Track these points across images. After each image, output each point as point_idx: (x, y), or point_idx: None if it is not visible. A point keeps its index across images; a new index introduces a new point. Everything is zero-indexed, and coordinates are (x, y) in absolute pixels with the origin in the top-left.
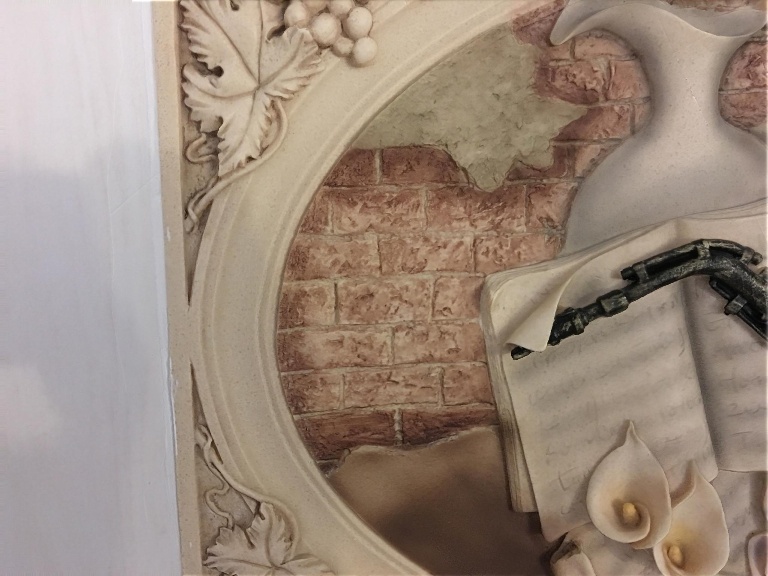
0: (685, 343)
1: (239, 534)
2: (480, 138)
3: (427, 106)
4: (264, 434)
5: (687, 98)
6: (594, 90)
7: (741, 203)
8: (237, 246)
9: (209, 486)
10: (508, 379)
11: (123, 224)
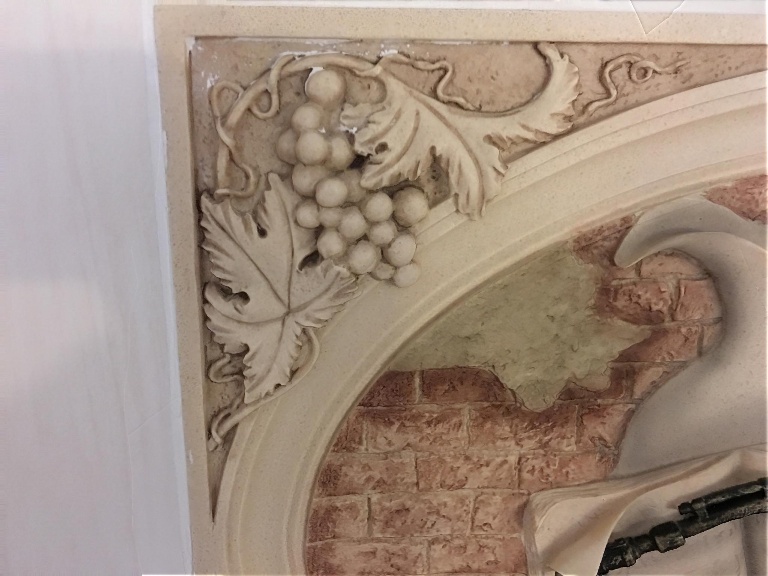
0: (741, 568)
1: None
2: (531, 360)
3: (474, 329)
4: None
5: (764, 326)
6: (660, 311)
7: None
8: (264, 461)
9: None
10: None
11: (142, 445)
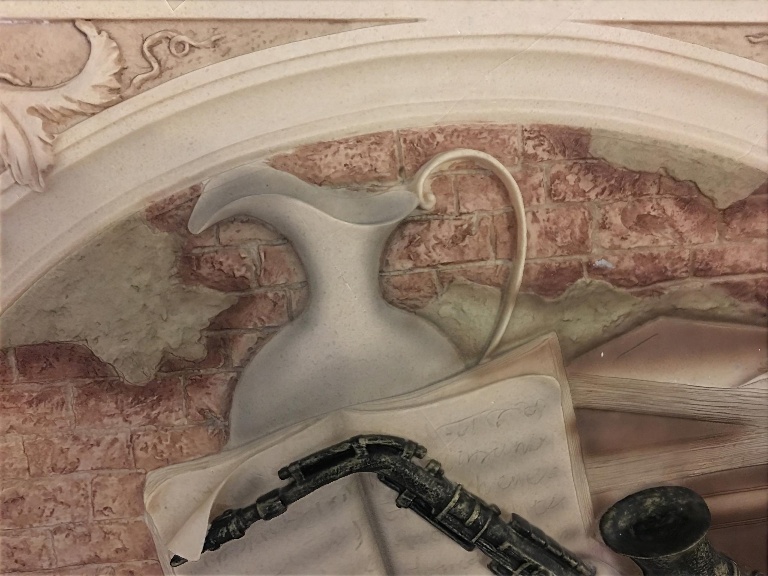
0: (363, 535)
1: None
2: (123, 332)
3: (58, 302)
4: None
5: (340, 285)
6: (244, 277)
7: (409, 389)
8: None
9: None
10: None
11: None
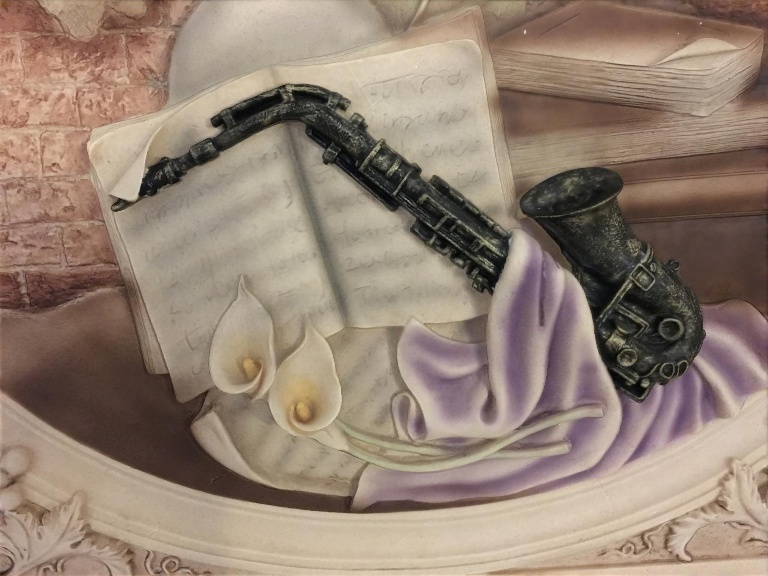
0: (293, 196)
1: None
2: None
3: None
4: None
5: None
6: None
7: (337, 51)
8: None
9: None
10: (122, 236)
11: None
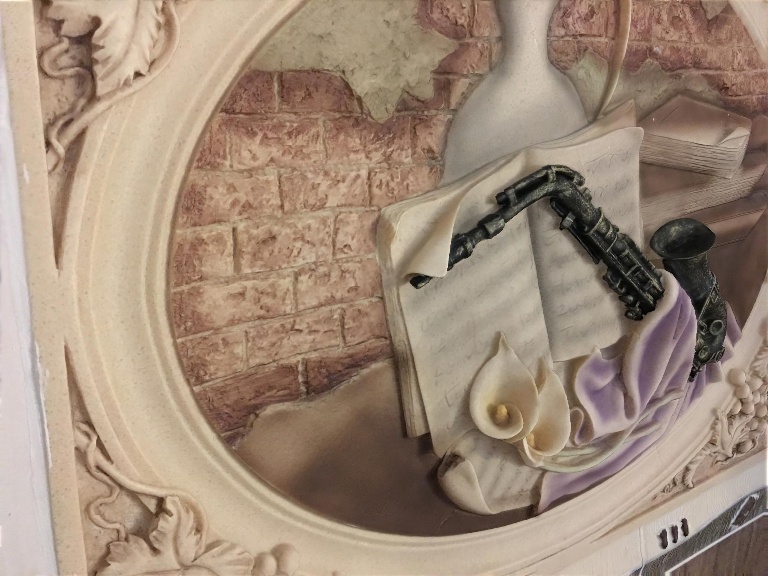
0: (532, 258)
1: (137, 543)
2: (374, 66)
3: (326, 27)
4: (156, 417)
5: (531, 40)
6: (463, 26)
7: (564, 135)
8: (114, 188)
9: (92, 497)
10: (404, 310)
11: None
